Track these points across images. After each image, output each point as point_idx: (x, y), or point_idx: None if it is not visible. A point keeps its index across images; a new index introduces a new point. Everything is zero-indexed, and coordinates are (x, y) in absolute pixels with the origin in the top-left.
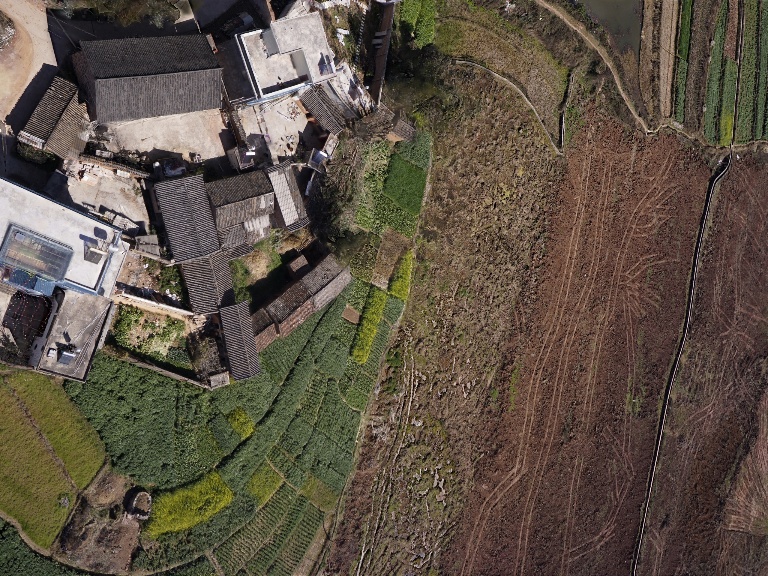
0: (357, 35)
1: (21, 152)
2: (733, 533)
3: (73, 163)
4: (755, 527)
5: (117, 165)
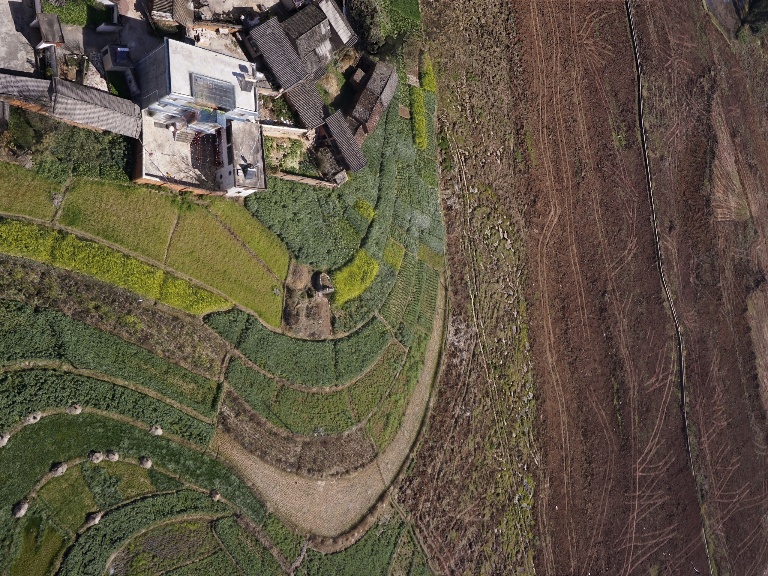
0: None
1: (160, 27)
2: (723, 223)
3: (189, 31)
4: (737, 215)
5: (219, 23)
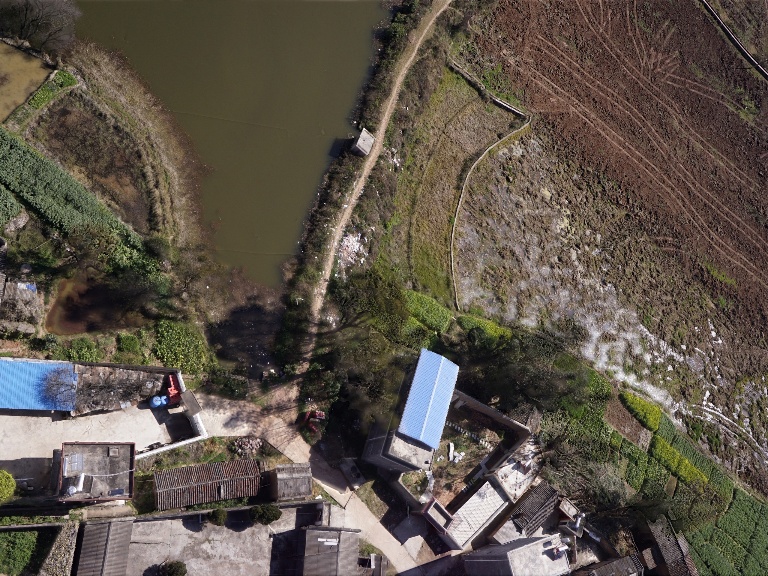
0: (452, 431)
1: None
2: None
3: None
4: None
5: None
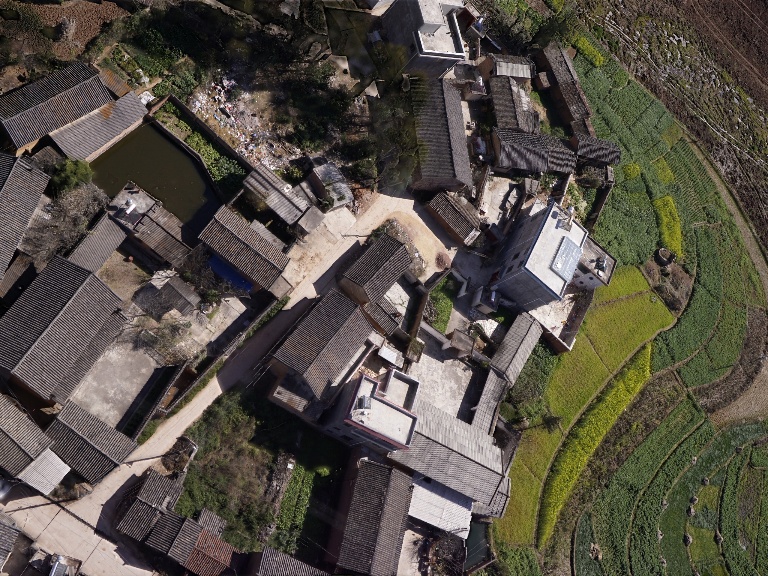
0: None
1: None
2: None
3: None
4: None
5: (484, 186)
